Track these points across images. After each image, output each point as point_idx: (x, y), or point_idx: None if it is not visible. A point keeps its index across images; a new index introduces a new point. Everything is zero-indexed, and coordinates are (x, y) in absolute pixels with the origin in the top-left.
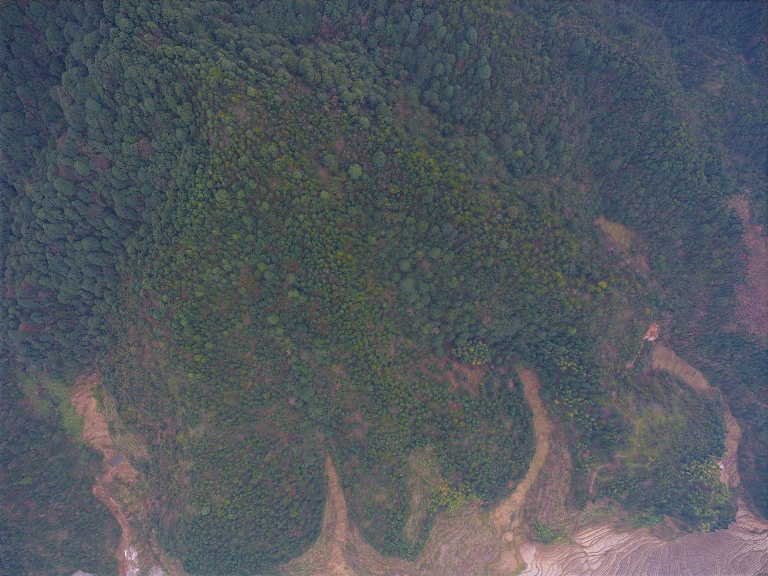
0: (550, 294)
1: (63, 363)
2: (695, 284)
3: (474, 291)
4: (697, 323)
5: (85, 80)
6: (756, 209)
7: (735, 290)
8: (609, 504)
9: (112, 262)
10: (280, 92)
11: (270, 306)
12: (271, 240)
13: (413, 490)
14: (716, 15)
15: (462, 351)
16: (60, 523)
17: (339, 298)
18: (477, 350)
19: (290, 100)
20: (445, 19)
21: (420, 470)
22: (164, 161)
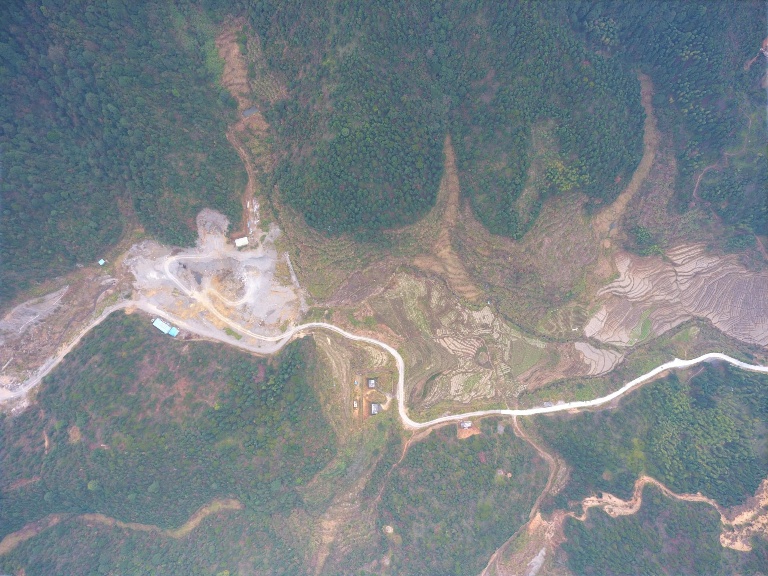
0: None
1: None
2: None
3: None
4: None
5: None
6: None
7: None
8: (708, 213)
9: None
10: None
11: None
12: None
13: (530, 163)
14: None
15: (593, 25)
16: (201, 144)
17: None
18: (607, 27)
19: None
20: None
21: (538, 147)
22: None
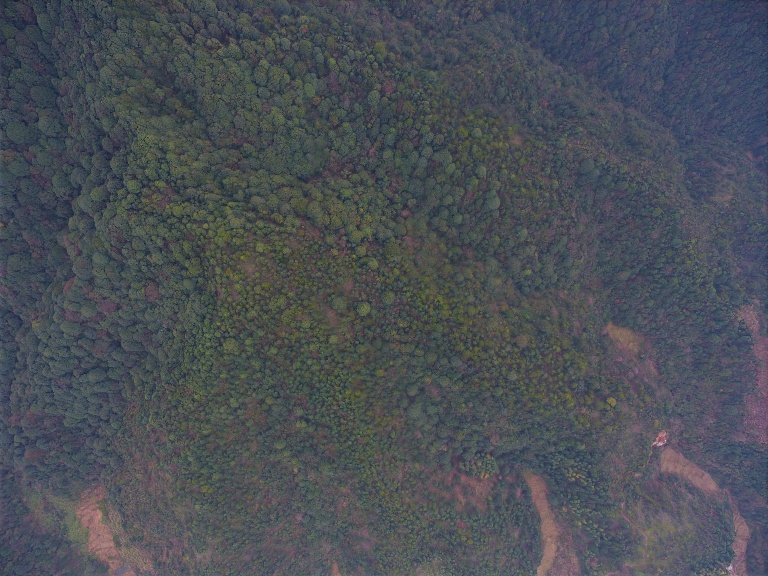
0: (559, 414)
1: (68, 481)
2: (704, 390)
3: (483, 417)
4: (706, 429)
5: (92, 234)
6: (766, 321)
7: (744, 400)
8: None
9: (118, 388)
10: (289, 242)
11: (277, 433)
12: (279, 378)
13: None
14: (724, 115)
15: (470, 465)
16: None
17: (347, 430)
18: (485, 463)
19: (298, 247)
20: (454, 157)
21: None
22: (171, 305)
